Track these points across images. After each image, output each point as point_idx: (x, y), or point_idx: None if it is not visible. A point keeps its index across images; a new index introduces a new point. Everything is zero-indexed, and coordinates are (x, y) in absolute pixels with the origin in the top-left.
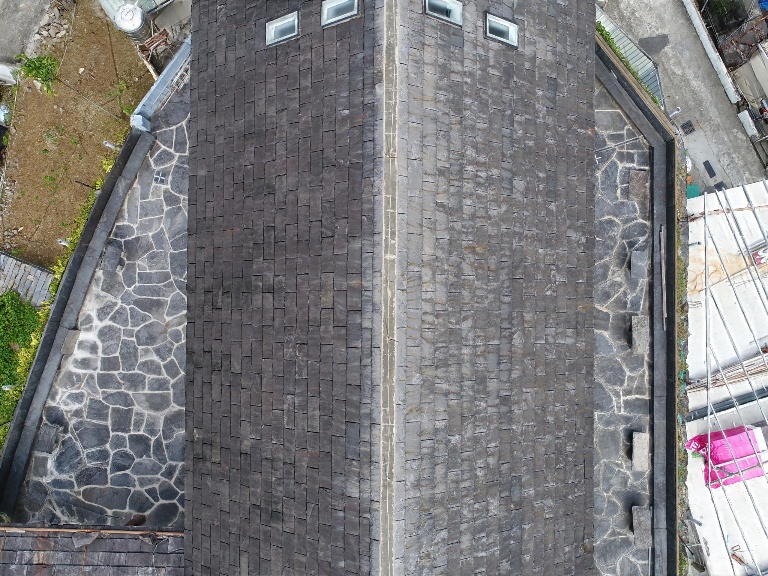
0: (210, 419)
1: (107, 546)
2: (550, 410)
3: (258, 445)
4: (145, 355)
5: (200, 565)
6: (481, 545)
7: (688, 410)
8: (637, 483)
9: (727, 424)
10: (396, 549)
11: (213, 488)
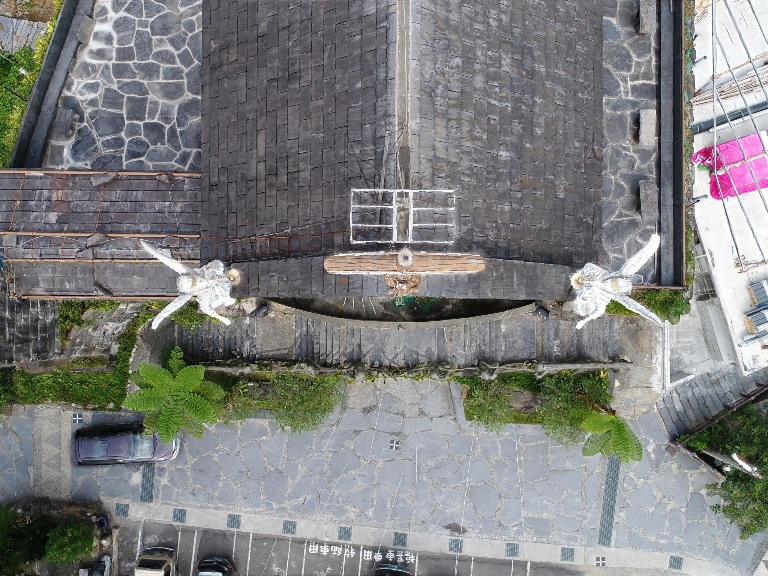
0: (227, 23)
1: (124, 186)
2: (561, 0)
3: (275, 20)
4: (159, 45)
5: (217, 169)
6: (494, 93)
7: (694, 87)
8: (644, 166)
9: (732, 137)
10: (412, 49)
11: (230, 87)
